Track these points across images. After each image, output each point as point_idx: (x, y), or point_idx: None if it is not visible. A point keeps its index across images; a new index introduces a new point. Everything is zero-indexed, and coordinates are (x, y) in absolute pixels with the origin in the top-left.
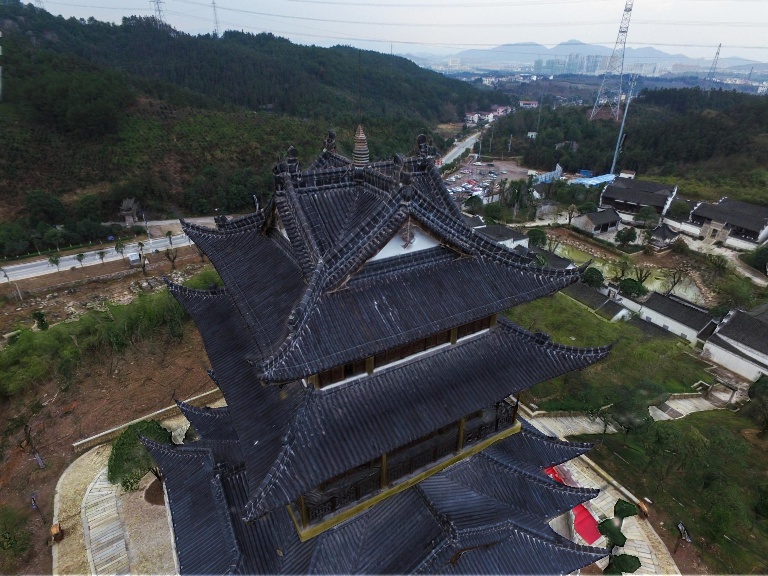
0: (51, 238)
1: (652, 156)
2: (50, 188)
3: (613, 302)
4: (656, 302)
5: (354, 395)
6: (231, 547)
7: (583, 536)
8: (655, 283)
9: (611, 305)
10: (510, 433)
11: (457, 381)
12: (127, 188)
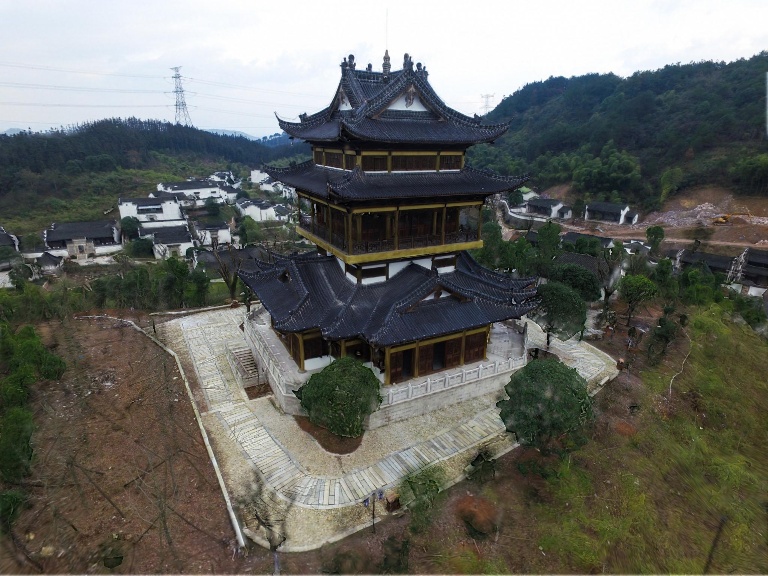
0: None
1: None
2: None
3: None
4: None
5: None
6: None
7: None
8: None
9: None
10: None
11: None
12: None
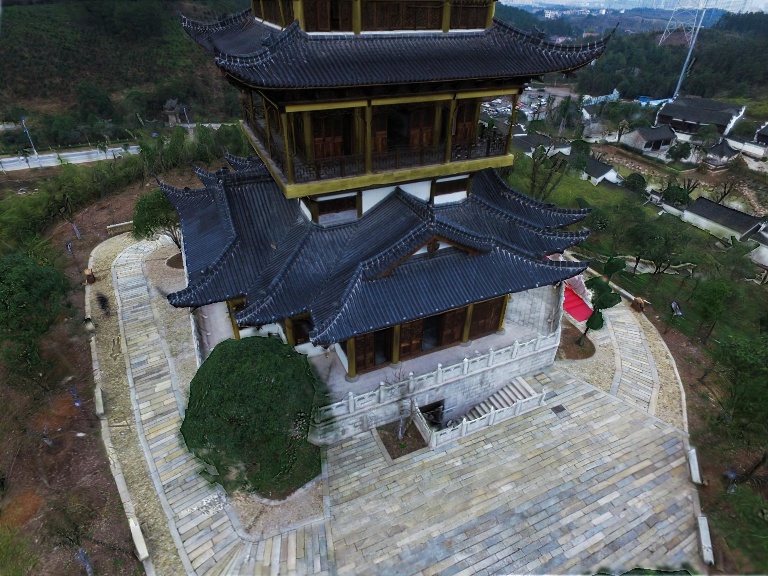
0: (100, 129)
1: (723, 80)
2: (99, 87)
3: (653, 204)
4: (700, 206)
5: (339, 47)
6: (229, 235)
7: (574, 316)
8: (703, 194)
9: (650, 206)
10: (502, 163)
11: (444, 57)
12: (170, 89)
